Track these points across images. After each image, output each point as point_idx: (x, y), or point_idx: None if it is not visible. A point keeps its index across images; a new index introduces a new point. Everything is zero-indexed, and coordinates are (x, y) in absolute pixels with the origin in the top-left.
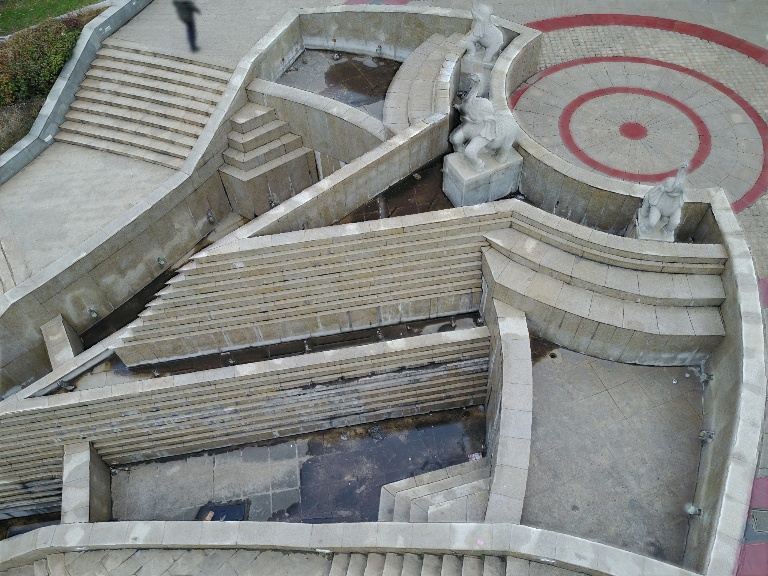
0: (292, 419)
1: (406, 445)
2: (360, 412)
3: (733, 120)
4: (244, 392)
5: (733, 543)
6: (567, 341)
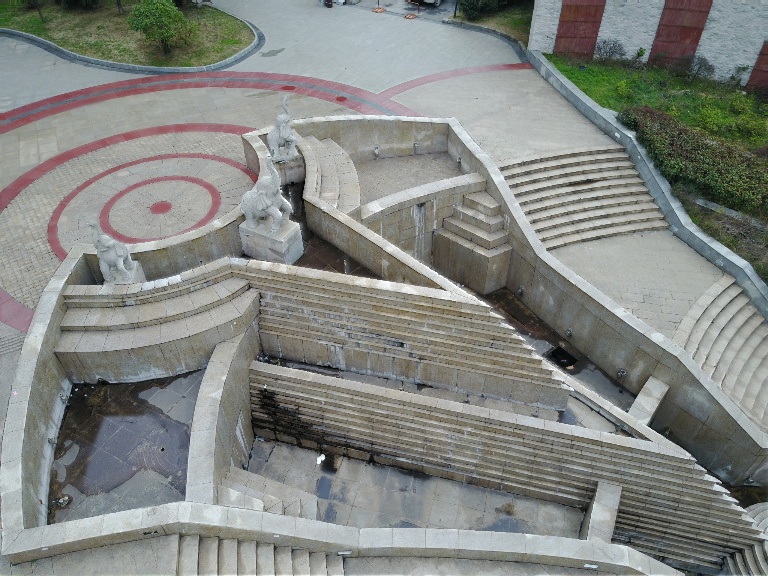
0: None
1: None
2: None
3: (127, 175)
4: None
5: None
6: None
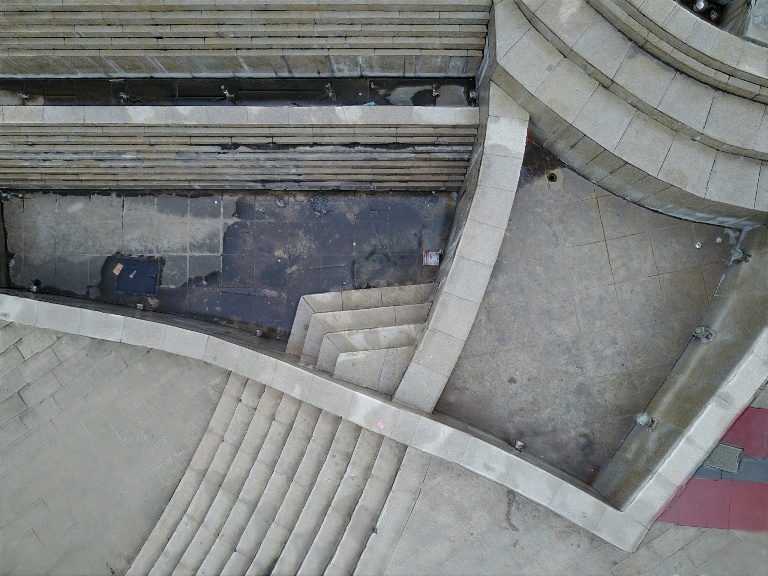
0: (213, 176)
1: (353, 226)
2: (300, 180)
3: None
4: (143, 141)
5: (670, 488)
6: (577, 164)
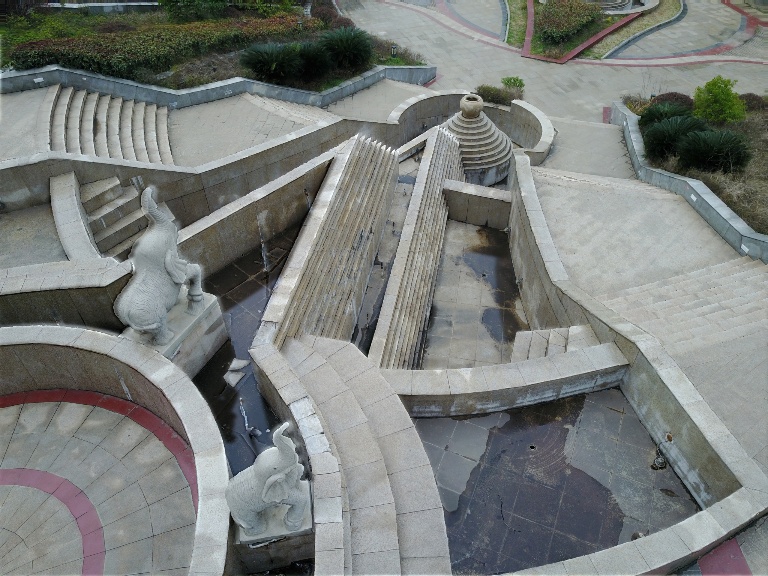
0: None
1: None
2: None
3: None
4: None
5: None
6: None
